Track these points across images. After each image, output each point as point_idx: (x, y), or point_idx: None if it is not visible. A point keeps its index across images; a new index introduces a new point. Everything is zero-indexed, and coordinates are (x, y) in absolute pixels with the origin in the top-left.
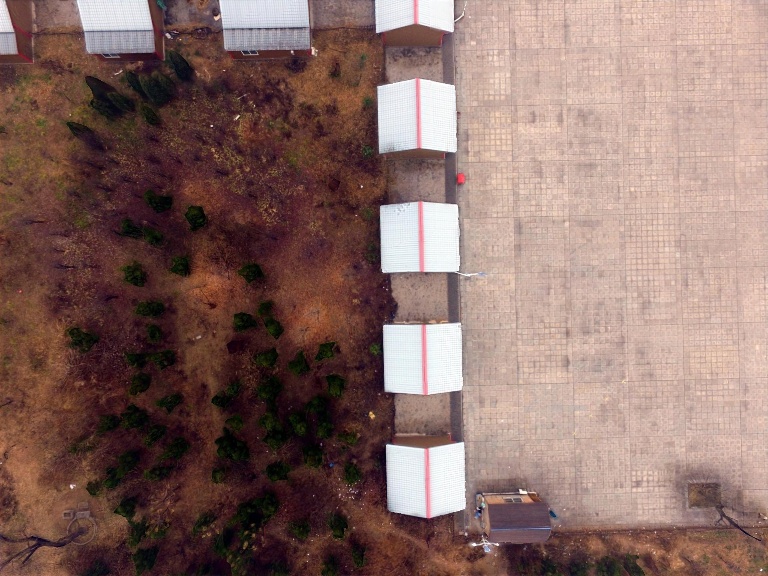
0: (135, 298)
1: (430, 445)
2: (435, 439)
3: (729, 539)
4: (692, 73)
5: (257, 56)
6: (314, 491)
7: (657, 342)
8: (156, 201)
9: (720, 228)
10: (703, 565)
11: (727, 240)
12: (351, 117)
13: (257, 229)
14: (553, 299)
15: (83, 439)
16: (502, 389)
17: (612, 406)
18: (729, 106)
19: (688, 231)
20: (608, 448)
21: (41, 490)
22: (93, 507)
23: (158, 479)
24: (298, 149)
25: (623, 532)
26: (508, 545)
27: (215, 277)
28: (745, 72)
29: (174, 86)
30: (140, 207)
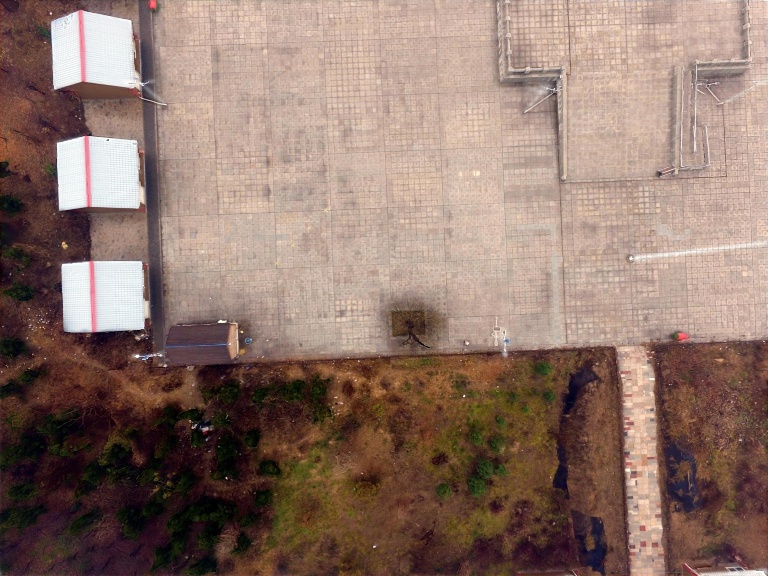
0: None
1: None
2: None
3: (433, 366)
4: None
5: None
6: (3, 322)
7: (359, 170)
8: None
9: (421, 54)
10: (405, 392)
11: (428, 66)
12: None
13: None
14: (253, 128)
15: None
16: (202, 219)
17: (315, 235)
18: None
19: (389, 58)
20: (311, 278)
21: None
22: None
23: None
24: None
25: (325, 361)
26: (205, 374)
27: None
28: None
29: None
30: None
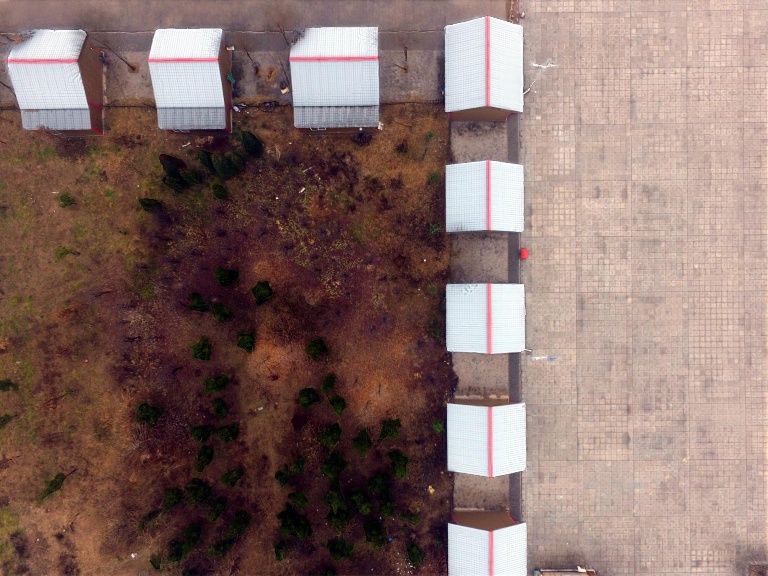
0: (198, 369)
1: (493, 526)
2: (494, 515)
3: None
4: (759, 150)
5: (324, 131)
6: (373, 565)
7: (719, 421)
8: (225, 278)
9: None
10: None
11: None
12: (415, 191)
13: (320, 302)
14: (614, 375)
15: (152, 517)
16: (562, 465)
17: (672, 484)
18: None
19: (752, 309)
20: (668, 527)
21: (103, 558)
22: (153, 575)
23: (222, 554)
24: (362, 222)
25: None
26: None
27: (278, 349)
28: None
29: (243, 162)
30: (205, 278)
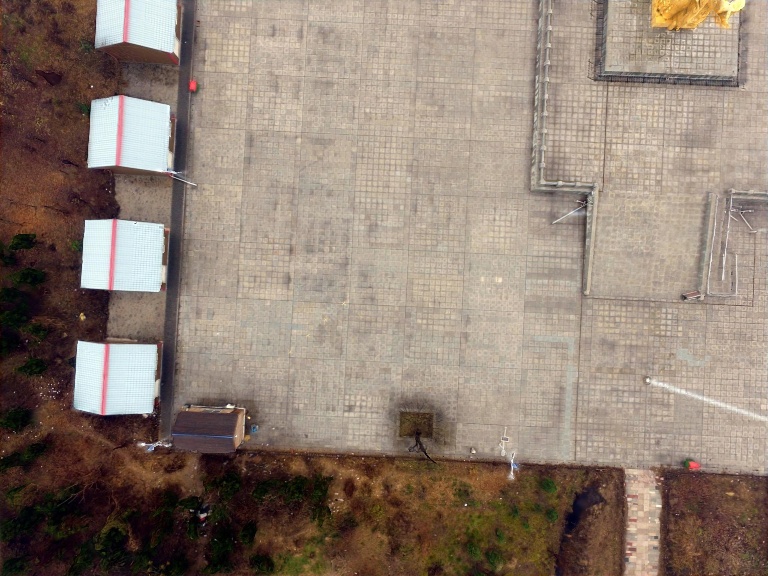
0: None
1: None
2: None
3: (437, 471)
4: None
5: None
6: (15, 387)
7: (381, 266)
8: None
9: (453, 156)
10: (406, 495)
11: (460, 168)
12: (86, 16)
13: None
14: (279, 215)
15: None
16: (220, 302)
17: (330, 327)
18: (471, 34)
19: (421, 156)
20: (323, 370)
21: None
22: None
23: None
24: (31, 44)
25: (329, 455)
26: (208, 458)
27: None
28: (490, 1)
29: None
30: None
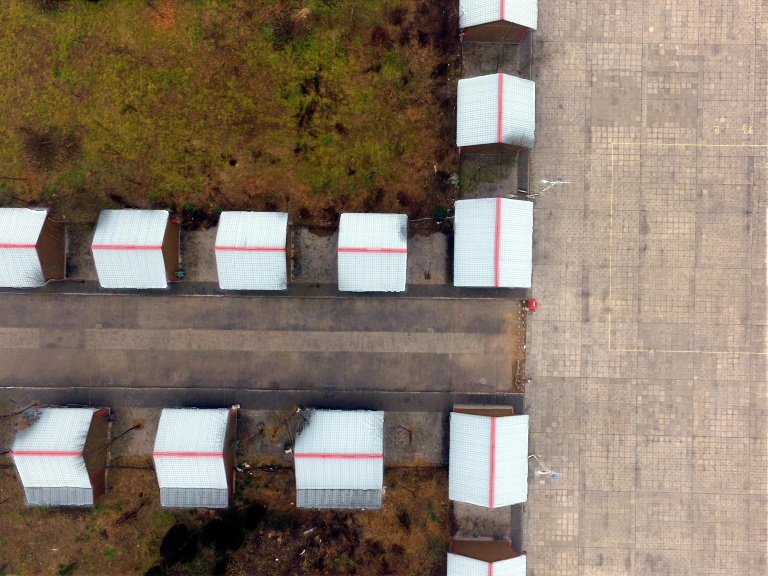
0: None
1: None
2: None
3: None
4: (765, 523)
5: None
6: None
7: None
8: None
9: None
10: None
11: None
12: (417, 556)
13: None
14: None
15: None
16: None
17: None
18: None
19: None
20: None
21: None
22: None
23: None
24: None
25: None
26: None
27: None
28: None
29: (244, 539)
30: None
